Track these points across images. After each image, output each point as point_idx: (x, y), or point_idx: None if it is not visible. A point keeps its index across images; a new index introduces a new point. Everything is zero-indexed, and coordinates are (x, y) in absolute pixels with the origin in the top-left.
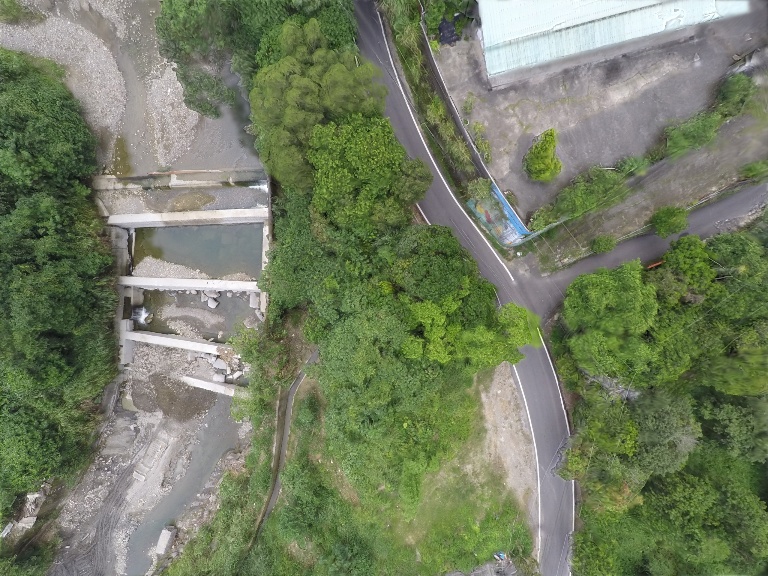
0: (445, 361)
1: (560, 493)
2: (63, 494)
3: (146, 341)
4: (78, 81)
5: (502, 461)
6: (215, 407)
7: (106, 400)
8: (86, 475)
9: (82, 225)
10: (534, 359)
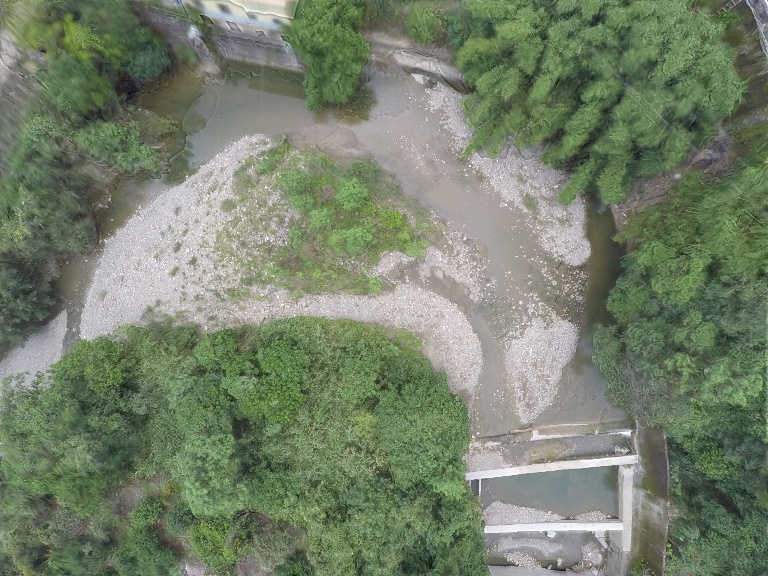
0: None
1: None
2: None
3: None
4: (434, 348)
5: None
6: None
7: None
8: None
9: (476, 508)
10: None
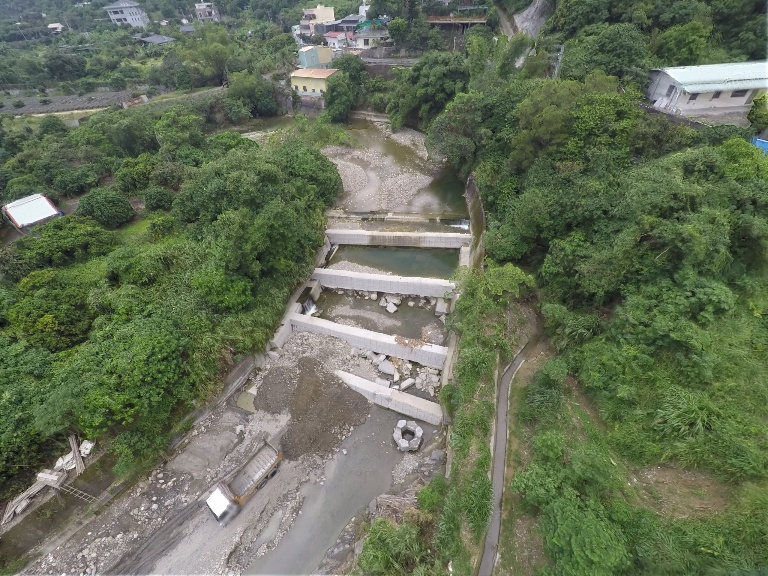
0: None
1: None
2: (61, 522)
3: (313, 323)
4: None
5: None
6: (364, 426)
7: (233, 376)
8: (117, 501)
9: (320, 212)
10: None
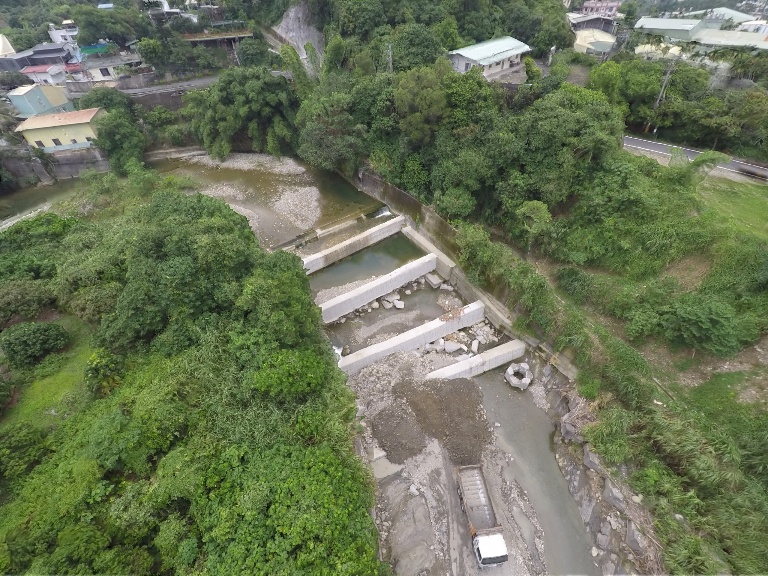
0: None
1: (763, 172)
2: None
3: (363, 356)
4: None
5: (711, 176)
6: (485, 398)
7: None
8: None
9: None
10: None
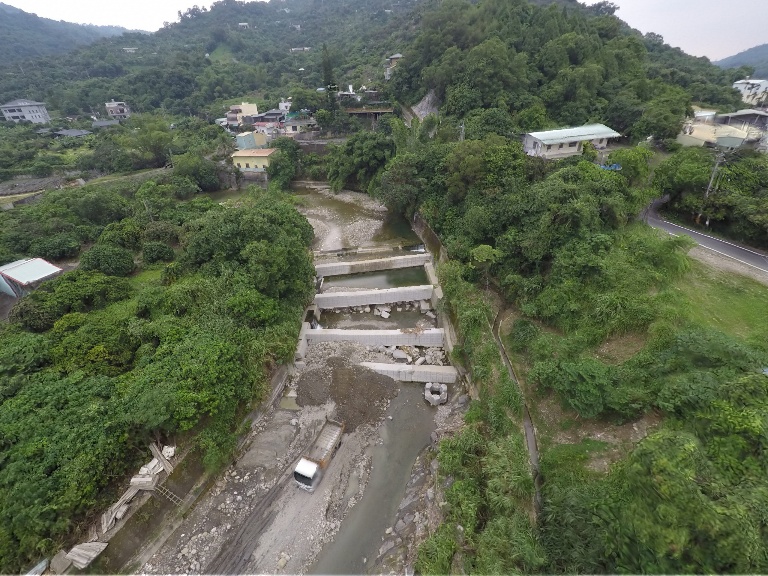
0: (617, 177)
1: None
2: (154, 529)
3: (327, 333)
4: None
5: (737, 274)
6: (398, 398)
7: (274, 382)
8: (200, 503)
9: None
10: (677, 230)
